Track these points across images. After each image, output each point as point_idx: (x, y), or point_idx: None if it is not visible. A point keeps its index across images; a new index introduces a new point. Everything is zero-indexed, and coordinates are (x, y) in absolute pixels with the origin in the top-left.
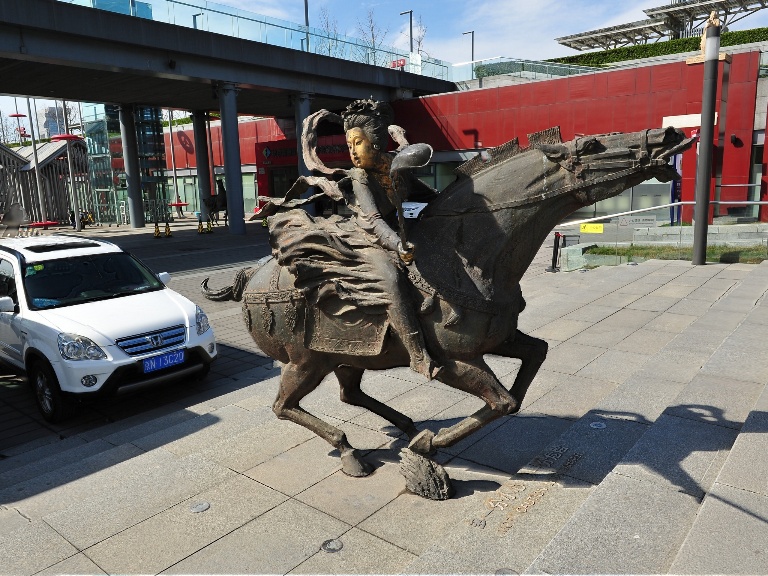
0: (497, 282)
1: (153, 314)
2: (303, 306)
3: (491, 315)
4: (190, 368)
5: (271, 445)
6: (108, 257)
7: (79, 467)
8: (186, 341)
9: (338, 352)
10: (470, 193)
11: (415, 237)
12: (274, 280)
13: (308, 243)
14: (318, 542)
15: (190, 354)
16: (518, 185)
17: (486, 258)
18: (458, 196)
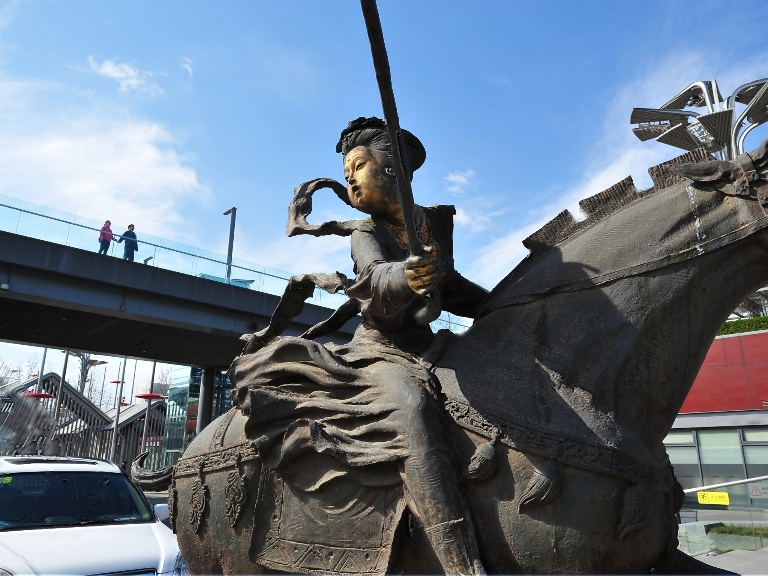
0: (625, 421)
1: (118, 550)
2: (257, 475)
3: (622, 483)
4: None
5: None
6: (97, 477)
7: None
8: None
9: (308, 572)
10: (556, 264)
11: (460, 347)
12: (220, 431)
13: (279, 362)
14: None
15: None
16: (645, 237)
17: (597, 371)
18: (535, 272)
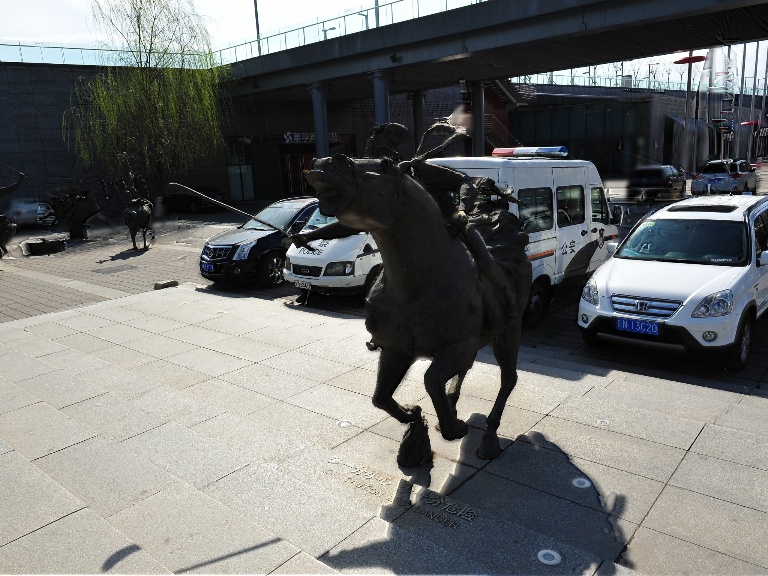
0: (387, 289)
1: (667, 284)
2: None
3: None
4: (667, 344)
5: (488, 391)
6: (719, 224)
7: (480, 356)
8: (671, 317)
9: None
10: None
11: None
12: None
13: None
14: (350, 420)
15: (671, 331)
16: None
17: None
18: None
